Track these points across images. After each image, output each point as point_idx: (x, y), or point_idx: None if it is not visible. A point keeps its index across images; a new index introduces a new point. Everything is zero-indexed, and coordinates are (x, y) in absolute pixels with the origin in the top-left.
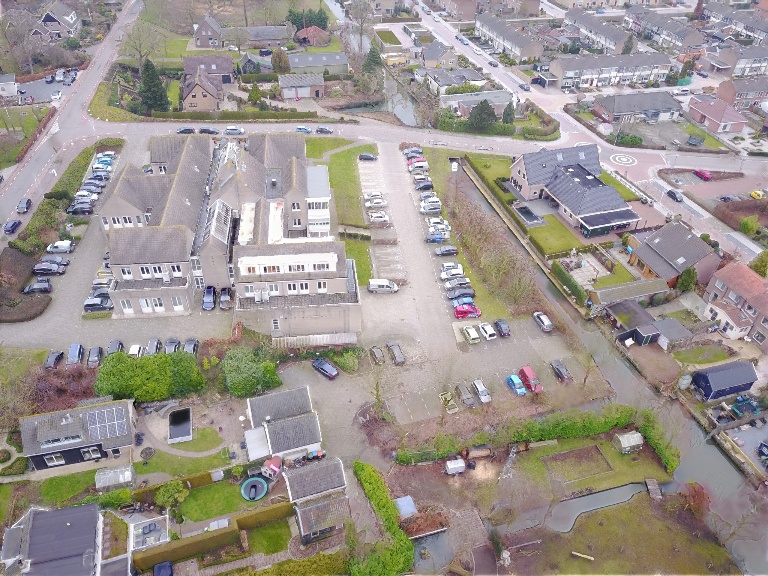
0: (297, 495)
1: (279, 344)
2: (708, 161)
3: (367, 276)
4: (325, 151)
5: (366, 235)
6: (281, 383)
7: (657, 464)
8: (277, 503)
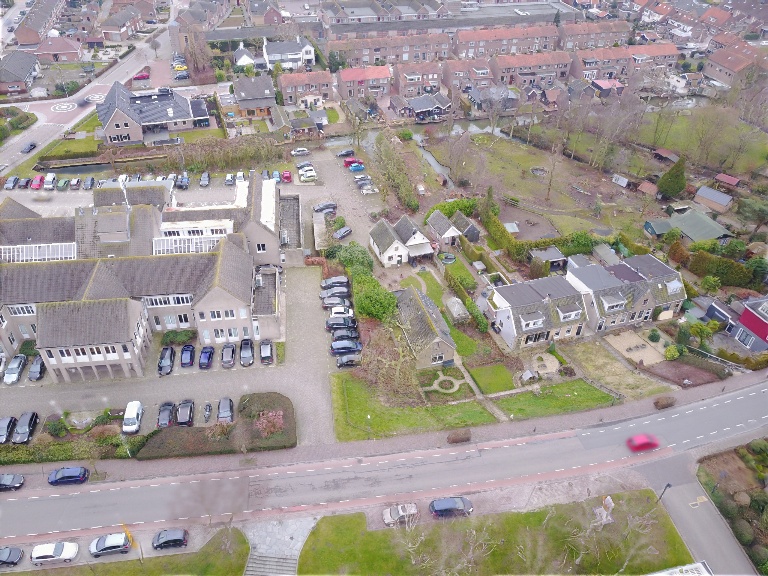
0: (458, 230)
1: (324, 246)
2: (120, 72)
3: None
4: None
5: None
6: None
7: (408, 141)
8: (463, 238)
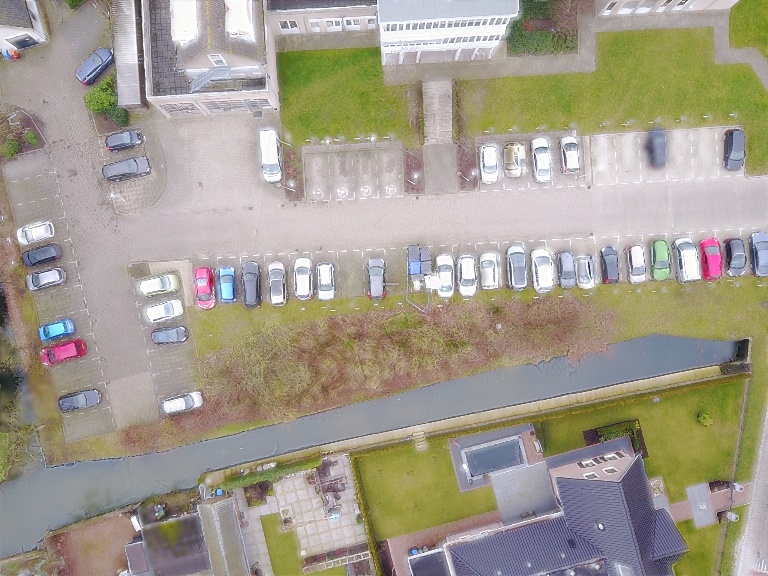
0: None
1: None
2: None
3: (308, 133)
4: (766, 52)
5: (423, 134)
6: (70, 6)
7: None
8: None
